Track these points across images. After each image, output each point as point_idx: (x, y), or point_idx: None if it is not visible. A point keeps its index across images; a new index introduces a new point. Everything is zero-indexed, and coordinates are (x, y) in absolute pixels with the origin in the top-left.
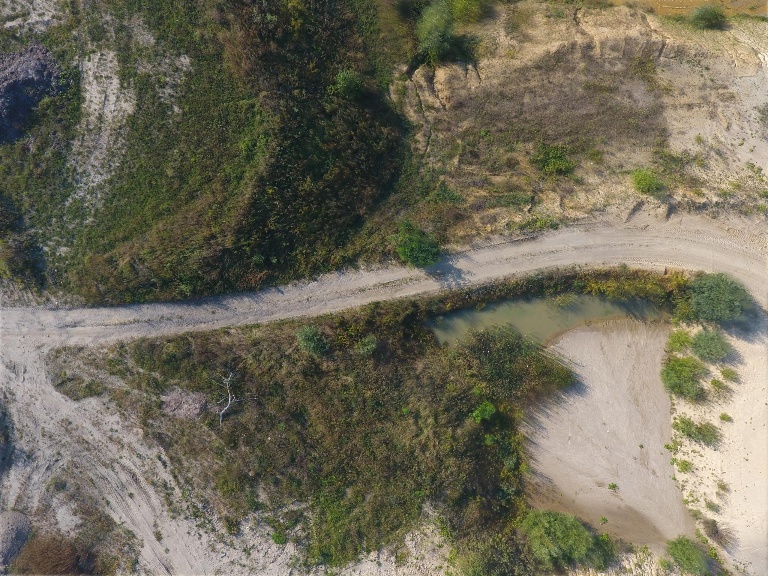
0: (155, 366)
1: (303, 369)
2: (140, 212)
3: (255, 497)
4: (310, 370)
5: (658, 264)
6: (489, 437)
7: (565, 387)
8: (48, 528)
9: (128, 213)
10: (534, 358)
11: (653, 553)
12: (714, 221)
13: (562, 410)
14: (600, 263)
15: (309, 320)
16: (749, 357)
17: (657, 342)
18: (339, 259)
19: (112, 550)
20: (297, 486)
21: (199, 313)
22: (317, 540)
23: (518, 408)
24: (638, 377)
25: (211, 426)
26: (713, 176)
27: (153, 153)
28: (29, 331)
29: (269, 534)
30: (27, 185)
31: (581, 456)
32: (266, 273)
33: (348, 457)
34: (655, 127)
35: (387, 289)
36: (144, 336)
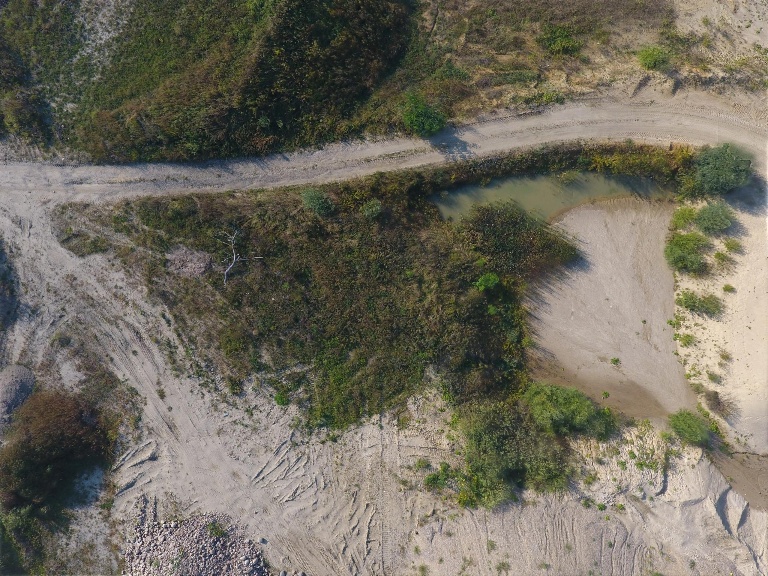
0: (160, 223)
1: (308, 229)
2: (147, 70)
3: (258, 357)
4: (315, 230)
5: (663, 139)
6: (492, 307)
7: (569, 262)
8: (52, 383)
9: (135, 71)
10: (538, 232)
11: (654, 427)
12: (720, 97)
13: (565, 286)
14: (605, 138)
15: (314, 188)
16: (753, 229)
17: (661, 221)
18: (345, 128)
19: (115, 407)
20: (300, 348)
21: (205, 175)
22: (319, 402)
23: (521, 280)
24: (642, 254)
25: (215, 284)
26: (719, 56)
27: (161, 11)
28: (35, 186)
29: (272, 395)
30: (35, 40)
31: (584, 331)
32: (272, 138)
33: (351, 319)
34: (662, 8)
35: (392, 160)
36: (150, 195)
